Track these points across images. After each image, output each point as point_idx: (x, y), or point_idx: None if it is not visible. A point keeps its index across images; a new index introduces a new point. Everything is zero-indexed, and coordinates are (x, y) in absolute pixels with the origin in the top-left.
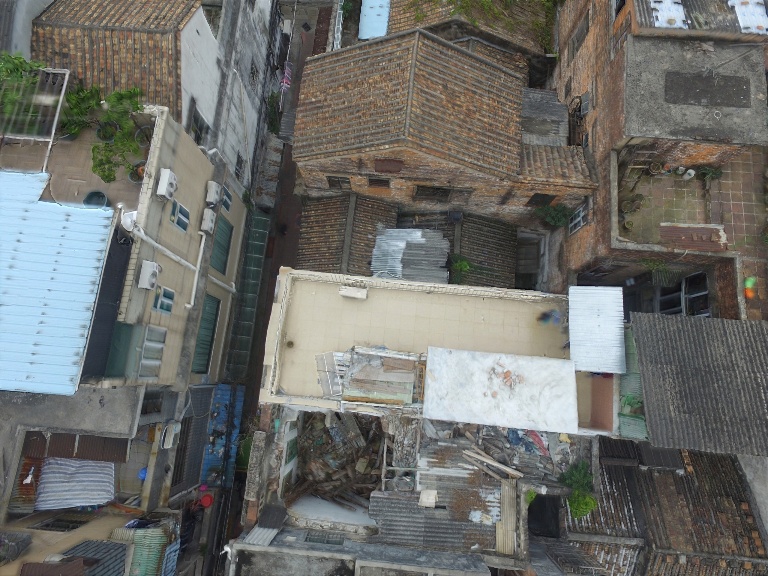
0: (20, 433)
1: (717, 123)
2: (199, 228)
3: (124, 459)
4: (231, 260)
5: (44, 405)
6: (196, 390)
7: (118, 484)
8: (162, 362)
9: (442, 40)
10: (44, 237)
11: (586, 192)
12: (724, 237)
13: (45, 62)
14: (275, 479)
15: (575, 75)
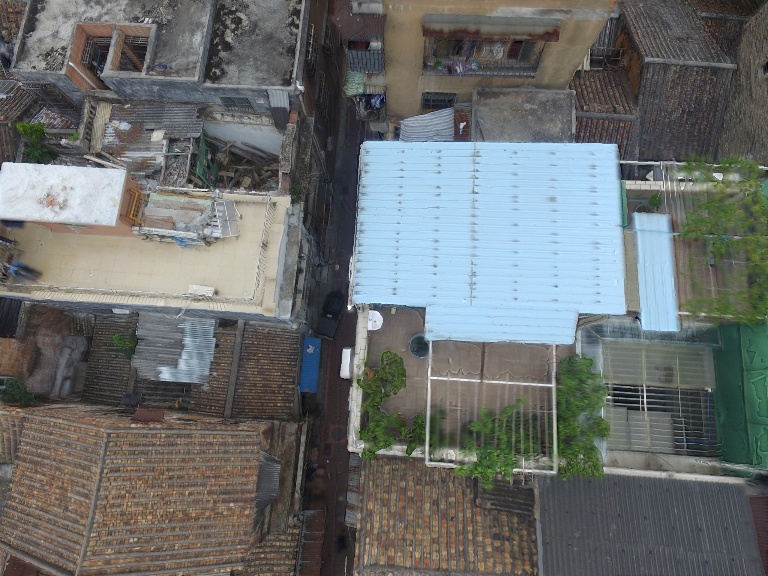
0: None
1: None
2: None
3: None
4: None
5: None
6: None
7: None
8: None
9: (54, 571)
10: (412, 271)
11: None
12: None
13: (520, 527)
14: None
15: None
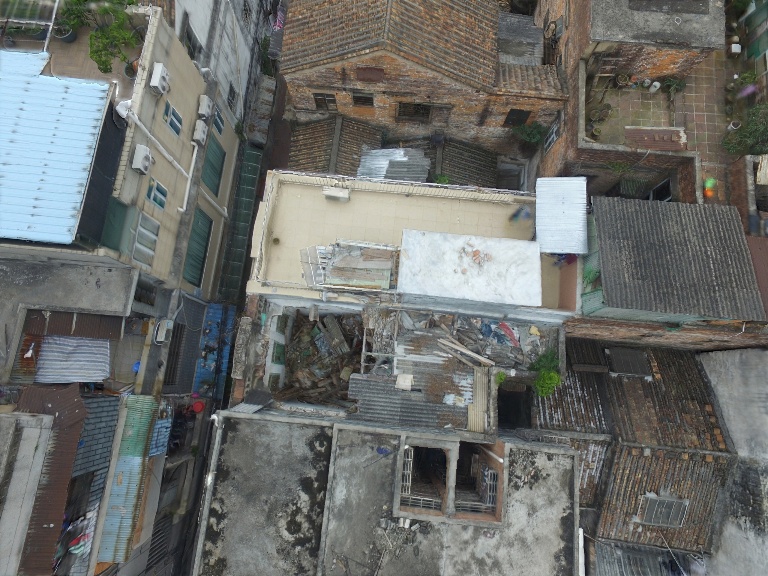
0: (21, 310)
1: (677, 28)
2: (191, 138)
3: (119, 337)
4: (223, 185)
5: (44, 286)
6: (189, 301)
7: (113, 372)
8: (155, 254)
9: None
10: (45, 106)
11: (558, 106)
12: (684, 137)
13: None
14: (261, 366)
15: (552, 6)
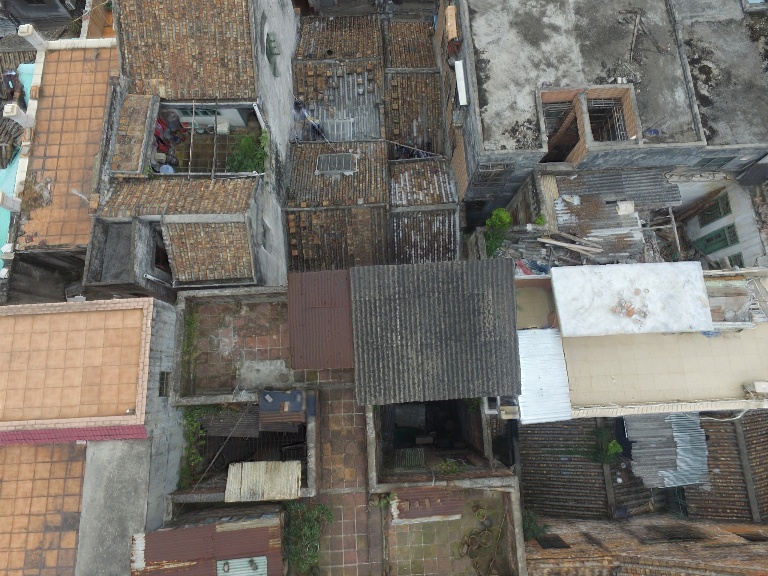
0: None
1: None
2: None
3: None
4: None
5: None
6: None
7: None
8: None
9: None
10: None
11: None
12: (395, 508)
13: None
14: (762, 205)
15: None
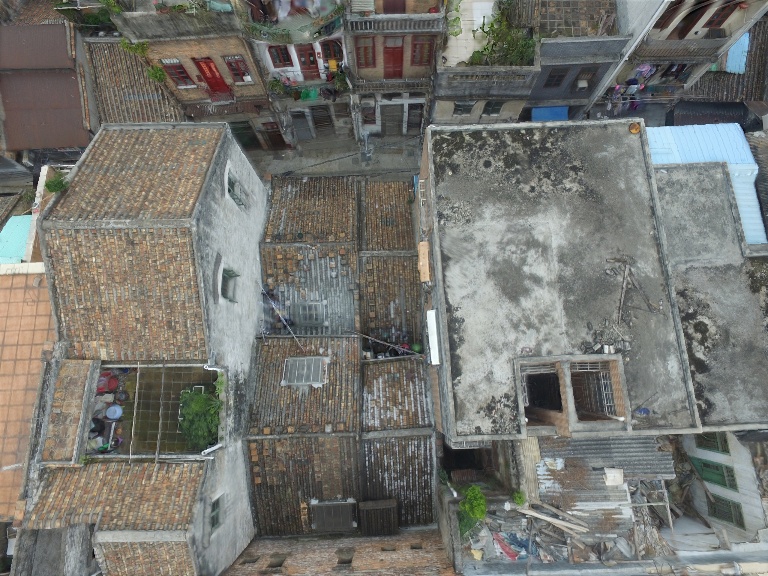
0: None
1: None
2: None
3: None
4: None
5: None
6: None
7: None
8: None
9: None
10: None
11: None
12: None
13: None
14: (764, 470)
15: None
